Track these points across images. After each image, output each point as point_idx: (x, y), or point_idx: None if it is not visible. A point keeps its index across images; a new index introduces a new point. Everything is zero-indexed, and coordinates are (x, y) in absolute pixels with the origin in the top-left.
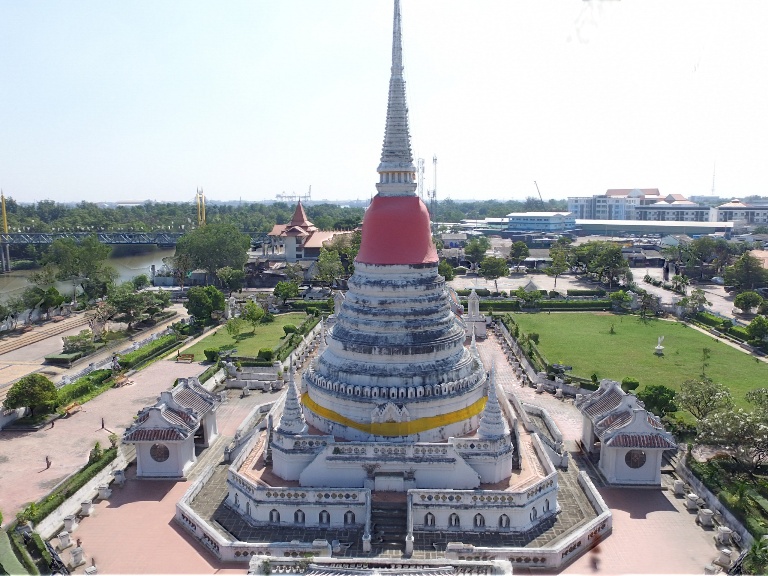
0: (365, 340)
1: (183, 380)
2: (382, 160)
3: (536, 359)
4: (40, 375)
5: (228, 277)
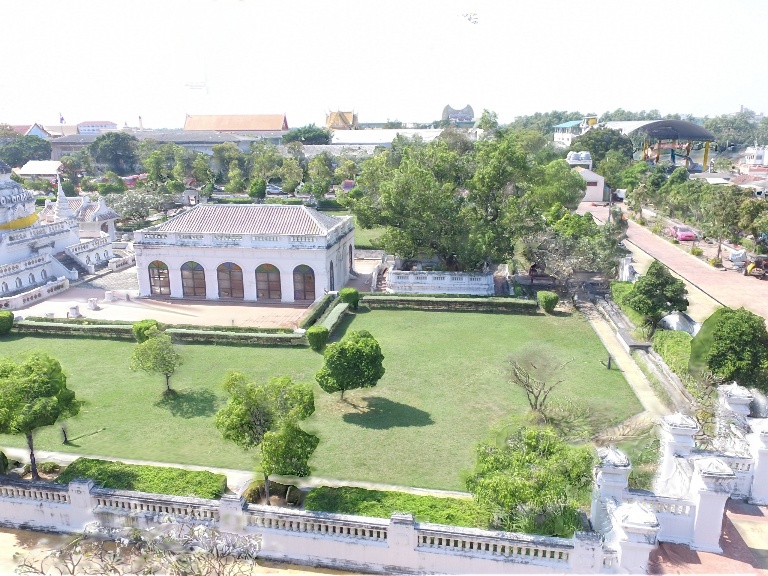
0: None
1: None
2: None
3: None
4: None
5: None
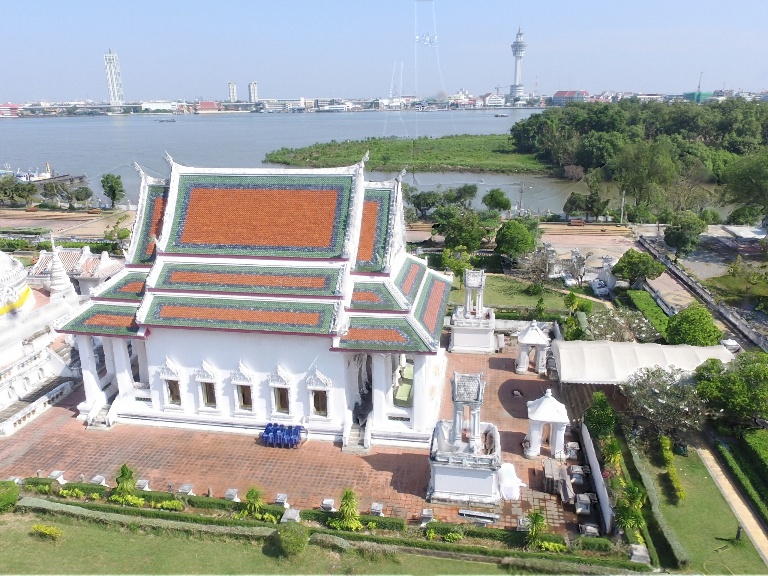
0: None
1: None
2: None
3: (123, 506)
4: None
5: (672, 226)
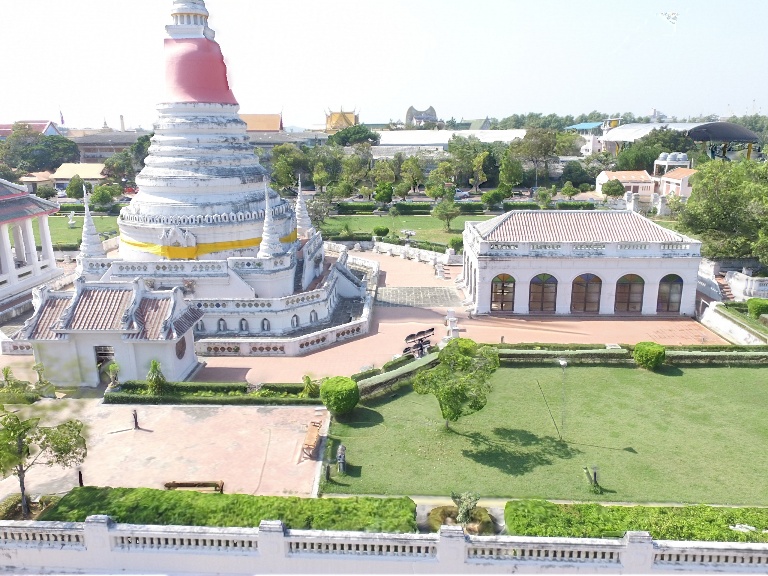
0: (253, 171)
1: (84, 279)
2: (194, 1)
3: None
4: None
5: None
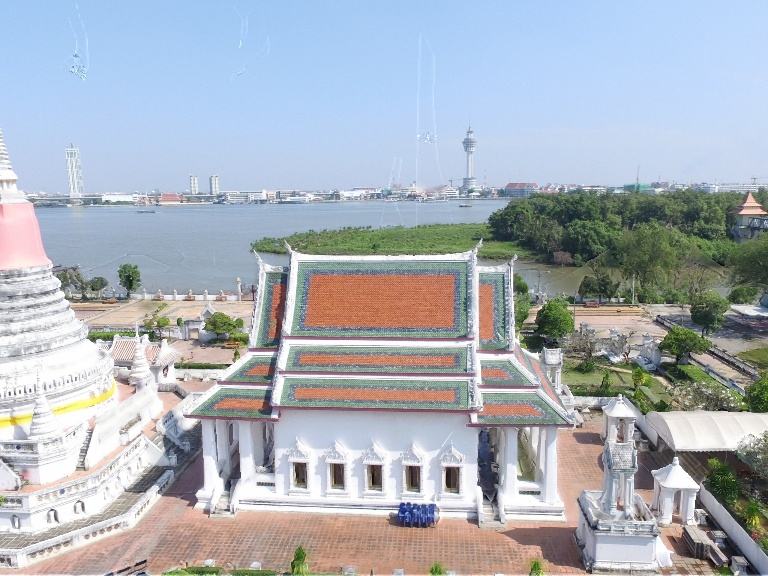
0: None
1: None
2: None
3: None
4: (219, 314)
5: (698, 305)
